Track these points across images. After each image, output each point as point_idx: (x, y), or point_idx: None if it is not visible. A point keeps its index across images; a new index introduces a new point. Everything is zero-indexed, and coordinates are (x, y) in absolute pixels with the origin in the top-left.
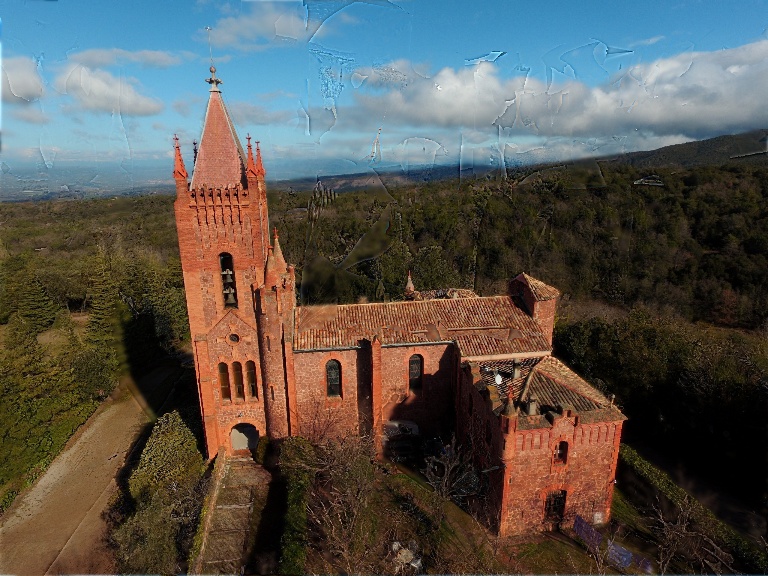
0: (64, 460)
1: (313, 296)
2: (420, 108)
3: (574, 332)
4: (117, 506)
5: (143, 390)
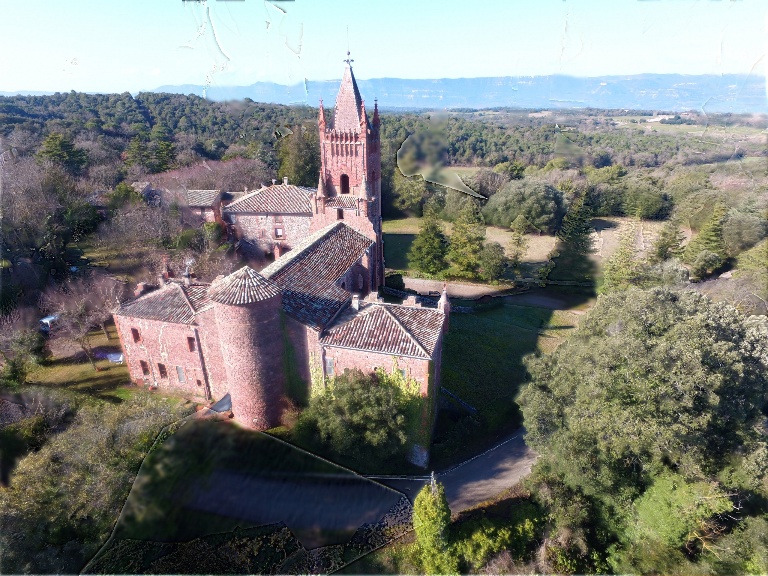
0: (434, 282)
1: None
2: None
3: None
4: None
5: (519, 298)
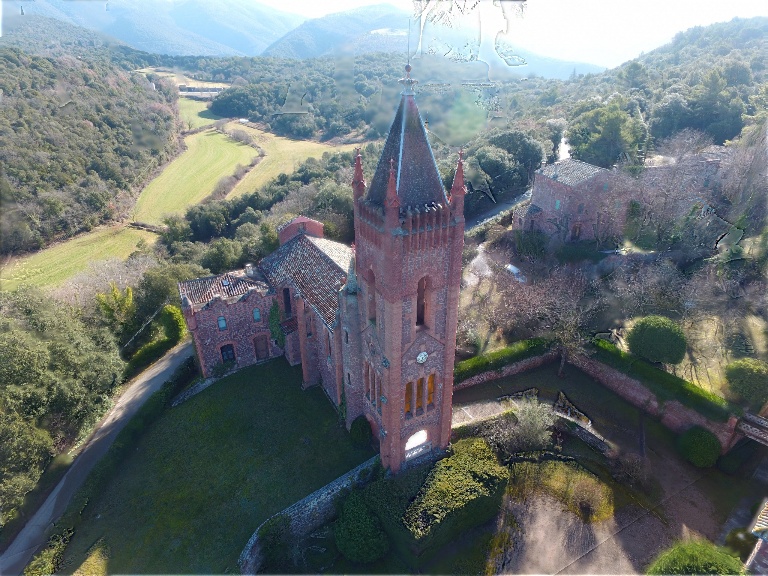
0: None
1: (600, 158)
2: (382, 103)
3: (165, 288)
4: (491, 571)
5: None
